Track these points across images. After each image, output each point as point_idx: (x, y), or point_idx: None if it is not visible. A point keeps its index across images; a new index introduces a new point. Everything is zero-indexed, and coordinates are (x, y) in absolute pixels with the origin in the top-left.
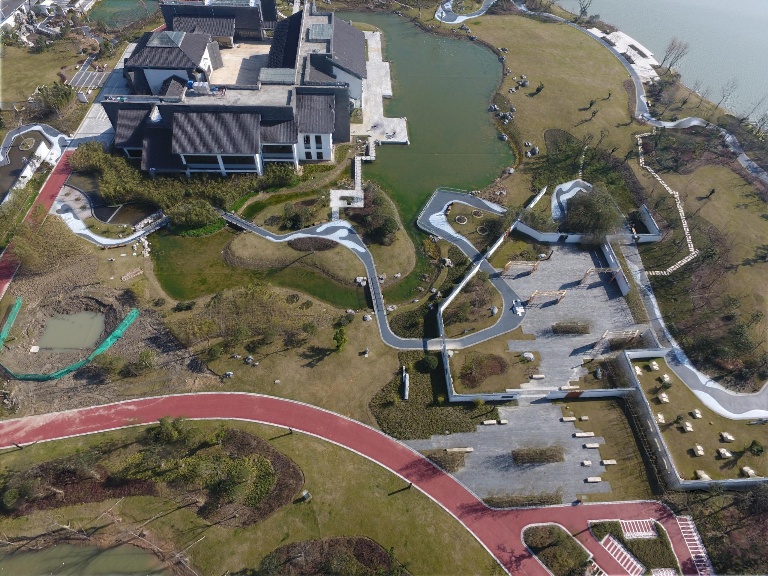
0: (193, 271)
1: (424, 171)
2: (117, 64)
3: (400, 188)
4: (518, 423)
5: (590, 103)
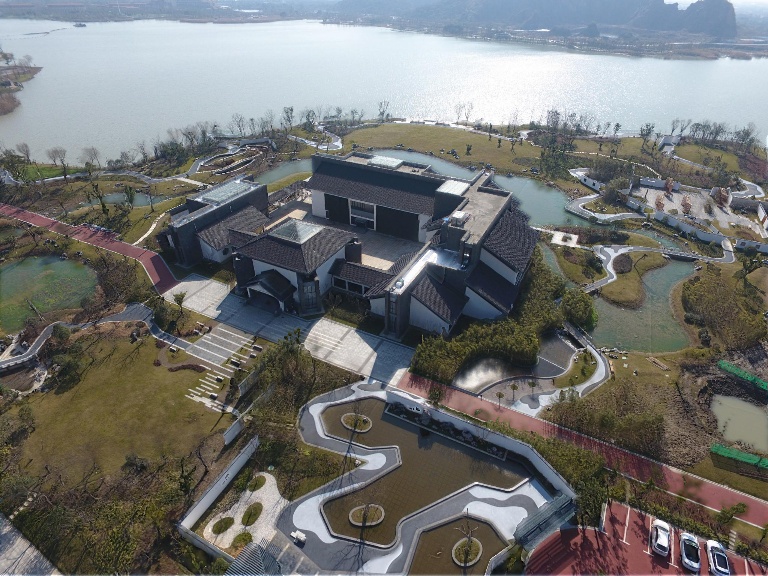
0: (648, 330)
1: (535, 208)
2: (204, 315)
3: (554, 220)
4: None
5: (498, 142)
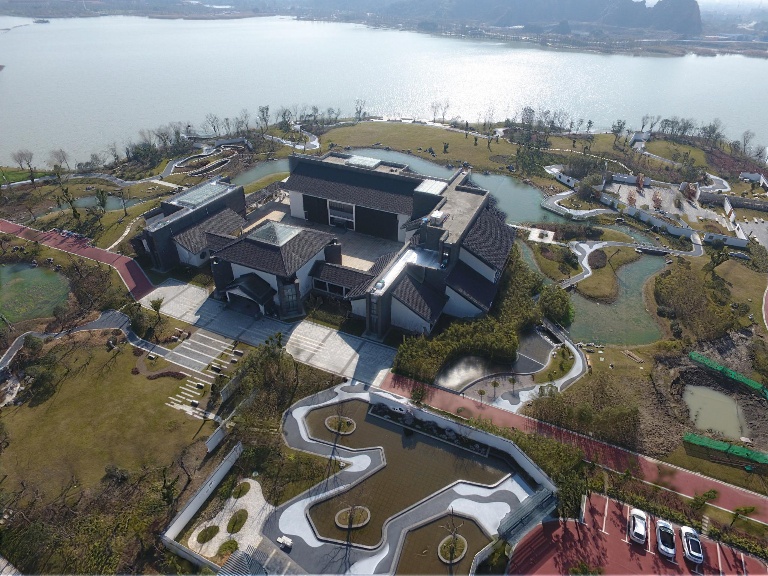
0: (623, 323)
1: (512, 205)
2: (183, 321)
3: (531, 217)
4: (753, 234)
5: (475, 140)
